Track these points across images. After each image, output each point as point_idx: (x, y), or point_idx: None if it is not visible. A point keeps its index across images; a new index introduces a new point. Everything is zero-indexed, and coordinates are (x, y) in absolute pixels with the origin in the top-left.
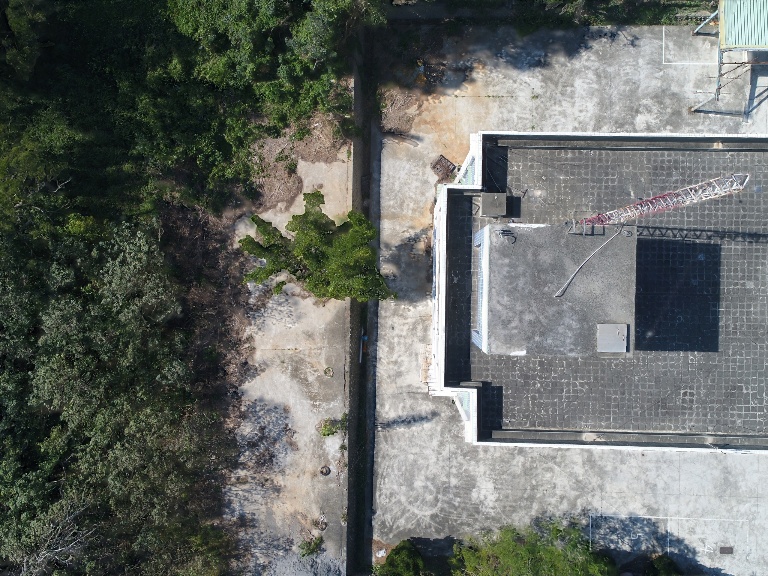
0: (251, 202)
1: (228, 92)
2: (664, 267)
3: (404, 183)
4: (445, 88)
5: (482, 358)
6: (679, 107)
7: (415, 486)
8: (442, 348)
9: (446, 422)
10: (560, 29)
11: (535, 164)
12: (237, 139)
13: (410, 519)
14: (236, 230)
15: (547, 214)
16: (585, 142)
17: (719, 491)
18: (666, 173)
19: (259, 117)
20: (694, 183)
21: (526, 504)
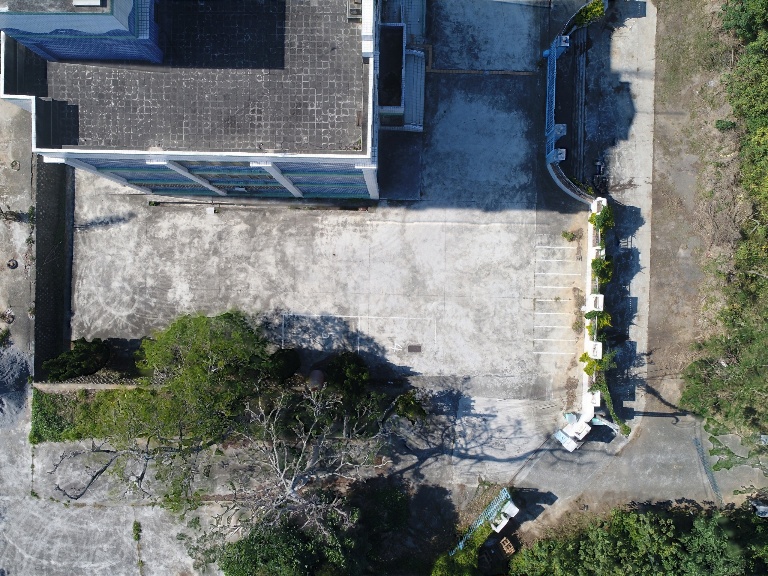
0: None
1: None
2: None
3: None
4: None
5: (58, 78)
6: None
7: (112, 287)
8: (2, 56)
9: (143, 223)
10: None
11: None
12: None
13: (107, 320)
14: None
15: None
16: None
17: (407, 290)
18: None
19: None
20: None
21: (221, 304)
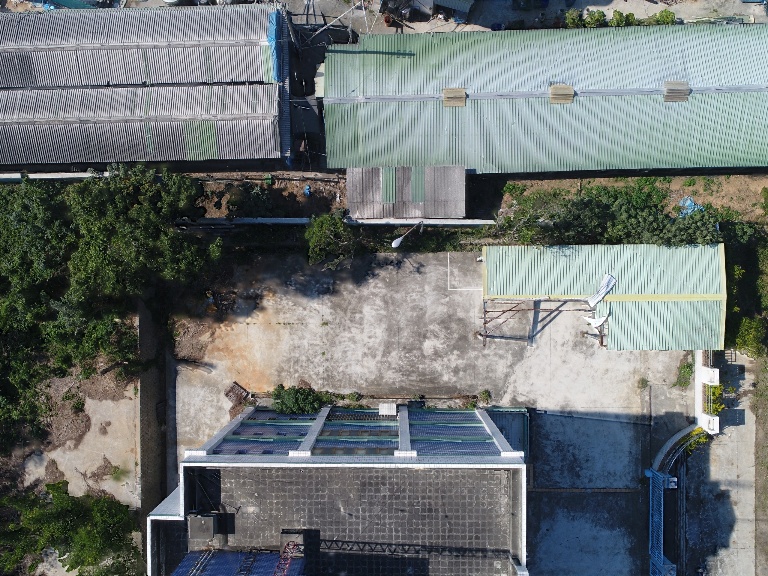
0: (40, 441)
1: (12, 334)
2: None
3: (199, 409)
4: (237, 316)
5: None
6: (465, 332)
7: None
8: None
9: None
10: None
11: (247, 481)
12: (21, 382)
13: None
14: (26, 468)
15: (260, 530)
16: None
17: None
18: (374, 489)
19: (45, 357)
20: (401, 499)
21: None
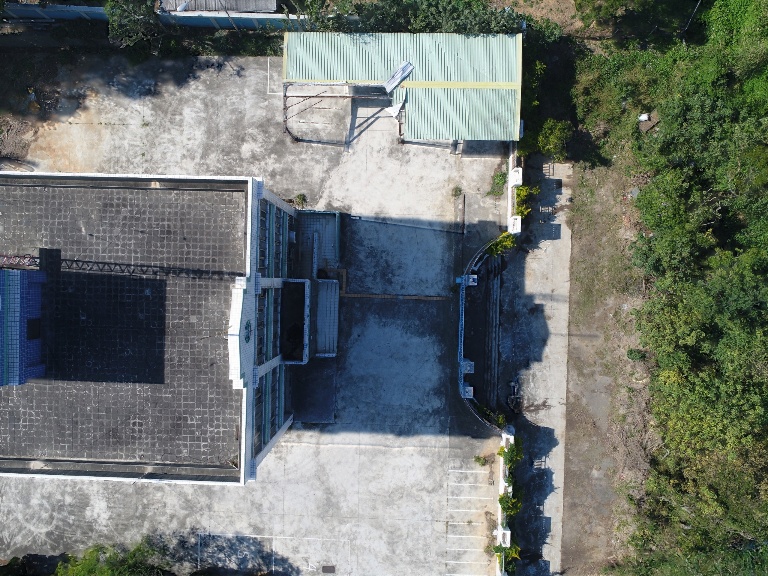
0: None
1: None
2: (113, 301)
3: None
4: (59, 115)
5: None
6: (283, 136)
7: (31, 504)
8: None
9: None
10: (169, 59)
11: None
12: None
13: (26, 536)
14: None
15: (4, 249)
16: (31, 180)
17: (322, 511)
18: (115, 210)
19: None
20: (141, 220)
21: (138, 522)
